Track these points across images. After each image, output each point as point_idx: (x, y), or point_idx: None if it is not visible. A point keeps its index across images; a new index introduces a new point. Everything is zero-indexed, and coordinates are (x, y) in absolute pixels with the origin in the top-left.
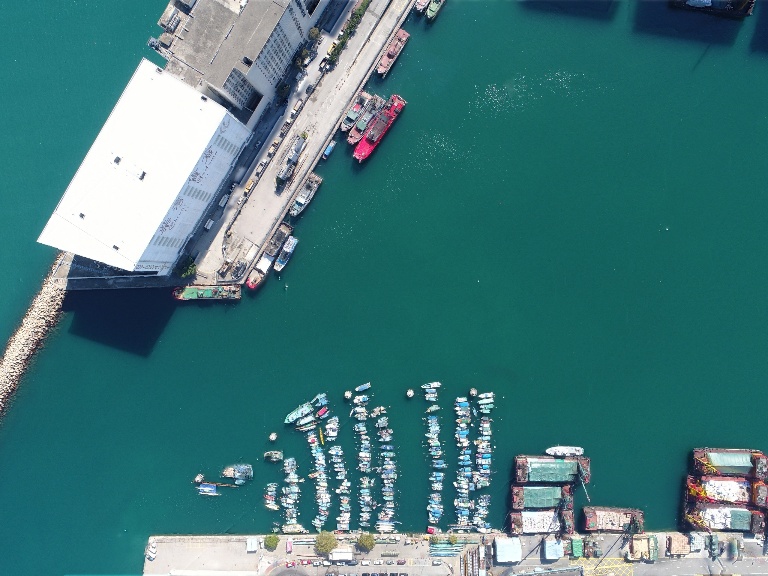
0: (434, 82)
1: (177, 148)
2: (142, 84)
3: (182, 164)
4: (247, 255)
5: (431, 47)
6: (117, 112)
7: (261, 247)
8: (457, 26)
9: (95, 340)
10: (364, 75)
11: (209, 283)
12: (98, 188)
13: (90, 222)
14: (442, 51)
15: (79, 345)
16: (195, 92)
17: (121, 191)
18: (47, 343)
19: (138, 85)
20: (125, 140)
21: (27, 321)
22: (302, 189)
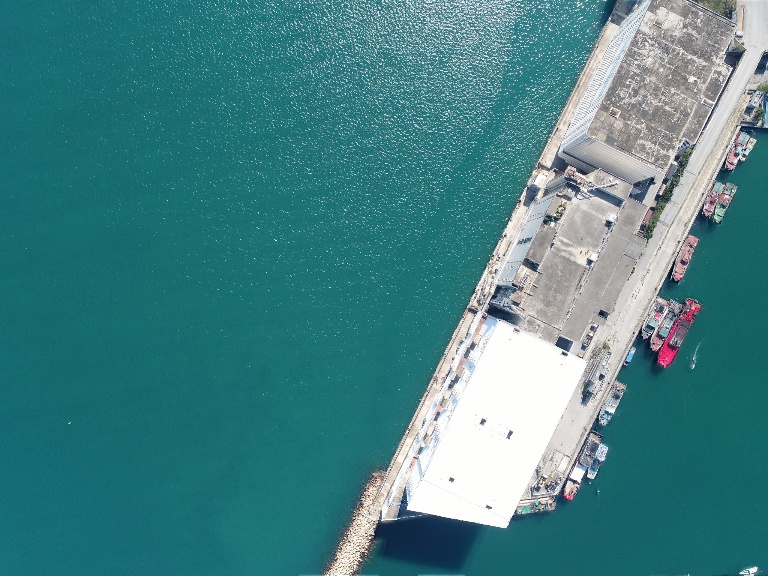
0: (723, 281)
1: (542, 404)
2: (500, 345)
3: (548, 419)
4: (559, 467)
5: (717, 248)
6: (476, 374)
7: (572, 457)
8: (741, 226)
9: (411, 565)
10: (659, 283)
11: (524, 498)
12: (466, 451)
13: (459, 484)
14: (729, 251)
15: (397, 573)
16: (554, 348)
17: (489, 452)
18: (361, 573)
19: (495, 346)
20: (488, 401)
21: (343, 556)
22: (609, 398)
